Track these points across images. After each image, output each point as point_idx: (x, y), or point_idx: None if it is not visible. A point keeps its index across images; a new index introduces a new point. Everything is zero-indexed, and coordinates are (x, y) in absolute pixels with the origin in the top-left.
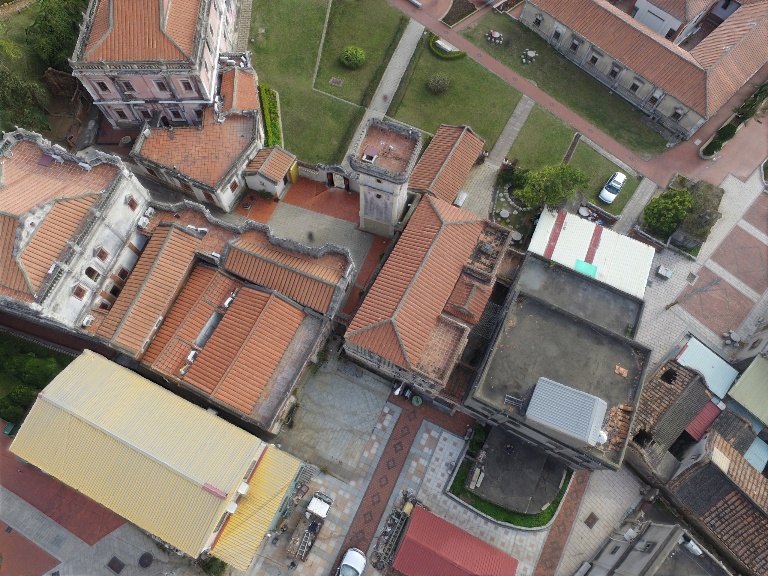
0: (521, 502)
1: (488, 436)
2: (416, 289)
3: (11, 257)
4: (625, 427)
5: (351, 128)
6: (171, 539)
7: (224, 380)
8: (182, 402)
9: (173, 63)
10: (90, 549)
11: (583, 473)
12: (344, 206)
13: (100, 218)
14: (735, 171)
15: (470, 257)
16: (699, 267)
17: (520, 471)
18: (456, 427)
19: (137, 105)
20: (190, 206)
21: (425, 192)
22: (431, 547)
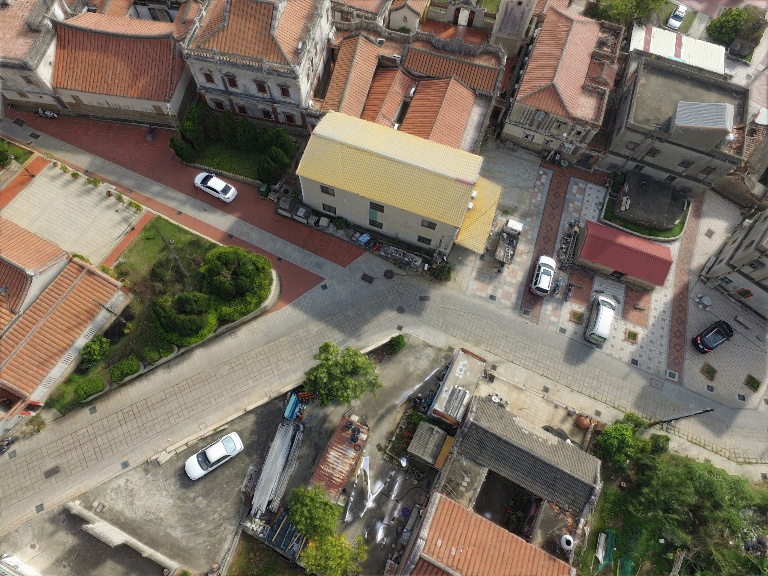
0: (660, 217)
1: (626, 178)
2: (564, 64)
3: (268, 37)
4: (741, 136)
5: None
6: (438, 217)
7: (433, 134)
8: (416, 138)
9: None
10: (344, 270)
11: (697, 205)
12: (469, 38)
13: (319, 16)
14: (767, 5)
15: (595, 48)
16: (753, 70)
17: (655, 198)
18: (597, 180)
19: None
20: (365, 25)
21: (541, 15)
22: (608, 238)
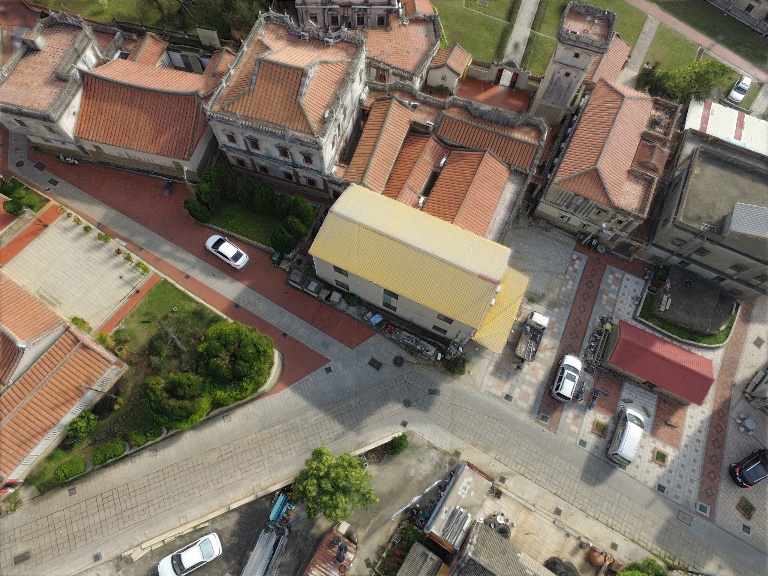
0: (704, 322)
1: (669, 273)
2: (610, 146)
3: (294, 103)
4: None
5: (506, 38)
6: (455, 316)
7: (459, 214)
8: (440, 221)
9: None
10: (352, 352)
11: (746, 308)
12: (510, 100)
13: (351, 80)
14: None
15: (646, 127)
16: None
17: (700, 299)
18: (636, 270)
19: (331, 10)
20: (399, 86)
21: (589, 83)
22: (643, 345)
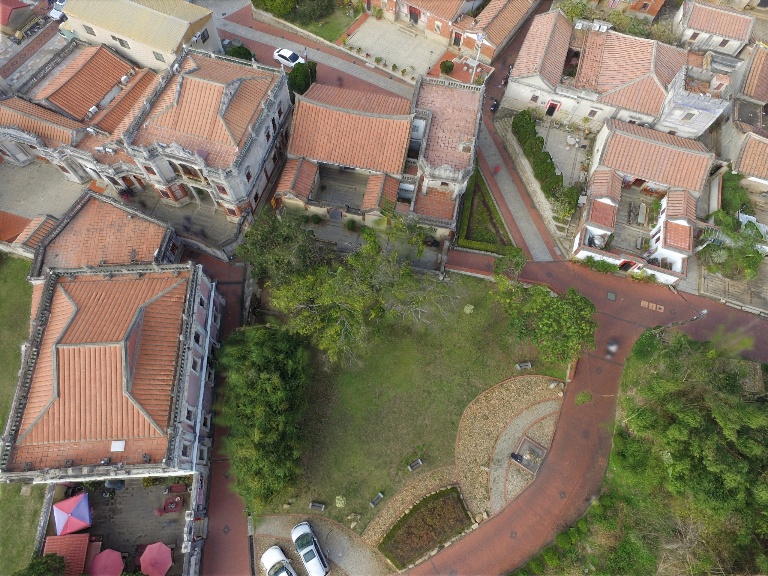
0: None
1: None
2: None
3: None
4: None
5: None
6: None
7: None
8: (108, 27)
9: (74, 268)
10: None
11: None
12: None
13: None
14: None
15: None
16: None
17: None
18: None
19: None
20: None
21: None
22: None
